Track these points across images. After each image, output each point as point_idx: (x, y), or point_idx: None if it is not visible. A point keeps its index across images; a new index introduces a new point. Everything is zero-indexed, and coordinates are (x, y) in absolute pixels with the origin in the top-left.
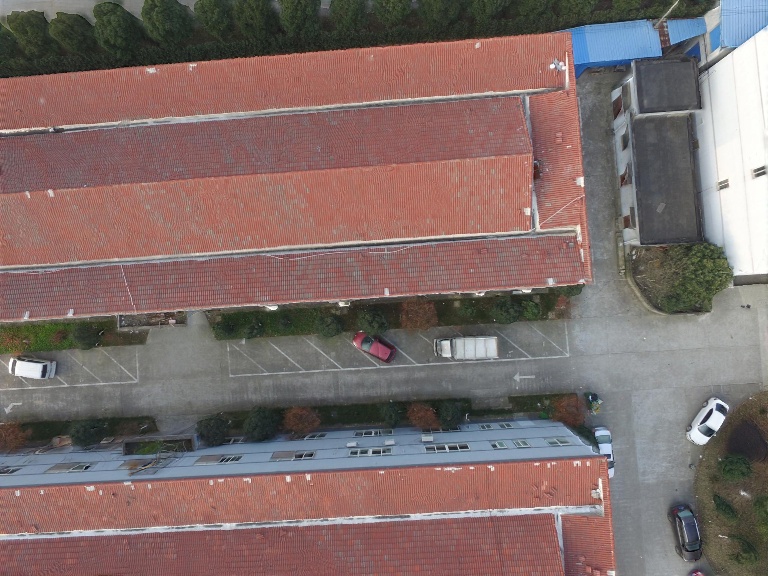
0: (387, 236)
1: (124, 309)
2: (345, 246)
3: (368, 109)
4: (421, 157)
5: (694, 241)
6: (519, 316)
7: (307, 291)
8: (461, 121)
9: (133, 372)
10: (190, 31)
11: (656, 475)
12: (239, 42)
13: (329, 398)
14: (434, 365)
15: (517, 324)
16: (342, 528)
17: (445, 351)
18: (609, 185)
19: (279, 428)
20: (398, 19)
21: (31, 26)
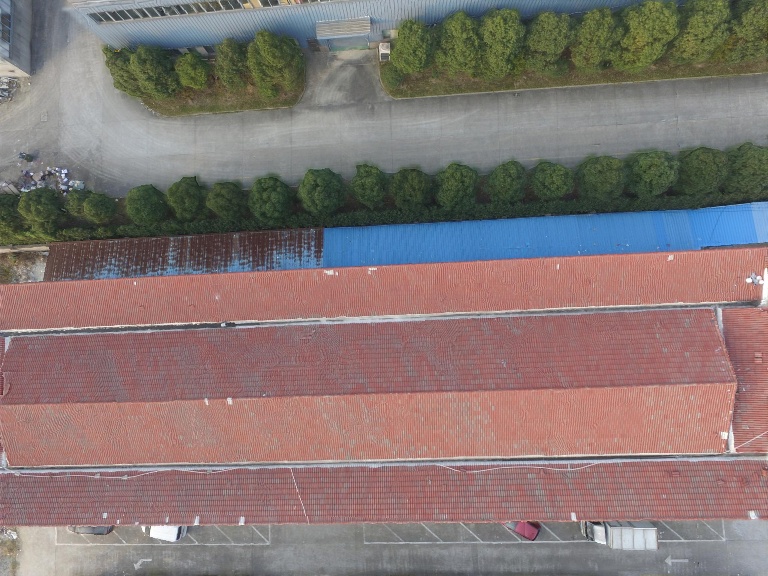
0: (570, 452)
1: (297, 520)
2: (524, 459)
3: (550, 316)
4: (615, 380)
5: None
6: None
7: (488, 511)
8: (650, 334)
9: (265, 533)
10: (342, 200)
11: None
12: (390, 211)
13: (468, 572)
14: (579, 542)
15: None
16: None
17: (599, 537)
18: None
19: None
20: (558, 196)
21: (189, 197)
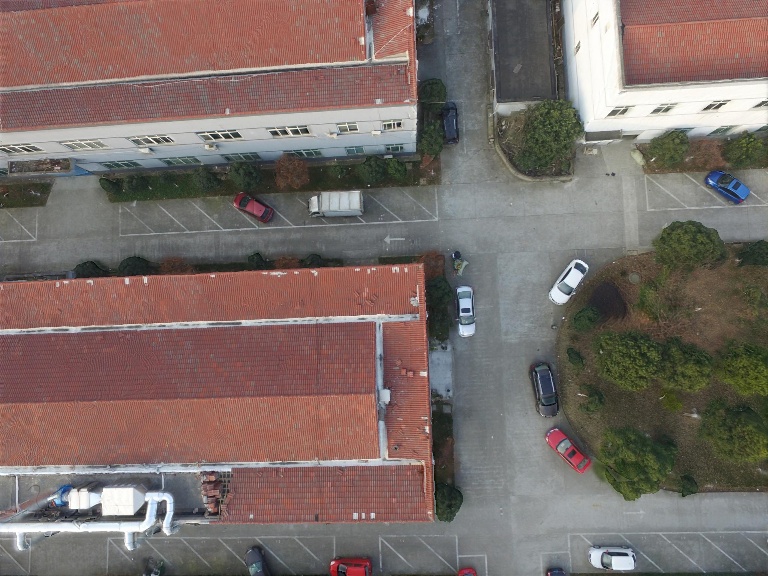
0: (235, 66)
1: None
2: (197, 76)
3: None
4: None
5: None
6: (391, 181)
7: (156, 112)
8: None
9: (32, 231)
10: None
11: (519, 335)
12: None
13: (210, 257)
14: (310, 227)
15: (390, 189)
16: (176, 331)
17: (313, 206)
18: (482, 62)
19: (152, 272)
20: None
21: None
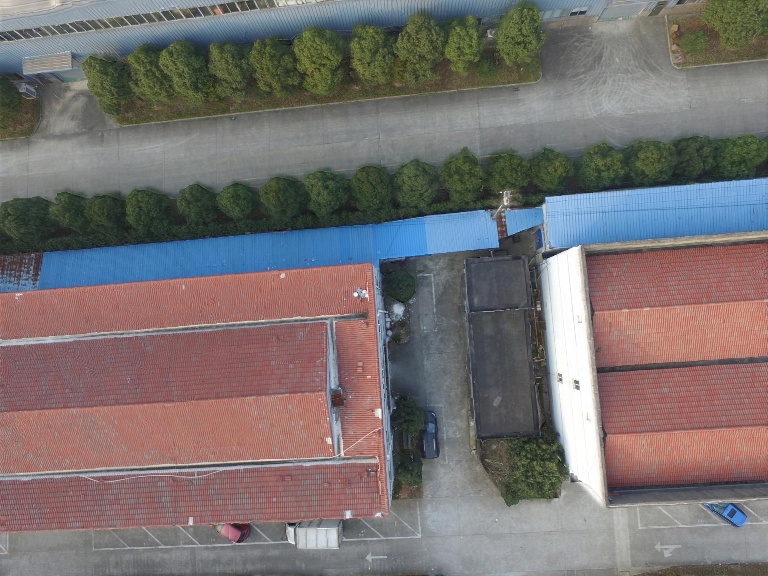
0: (197, 460)
1: None
2: (159, 468)
3: (182, 334)
4: (221, 392)
5: (531, 435)
6: None
7: (117, 518)
8: (269, 347)
9: (3, 543)
10: (51, 226)
11: None
12: (97, 235)
13: (186, 574)
14: (288, 543)
15: None
16: None
17: (290, 538)
18: (461, 362)
19: None
20: None
21: None
